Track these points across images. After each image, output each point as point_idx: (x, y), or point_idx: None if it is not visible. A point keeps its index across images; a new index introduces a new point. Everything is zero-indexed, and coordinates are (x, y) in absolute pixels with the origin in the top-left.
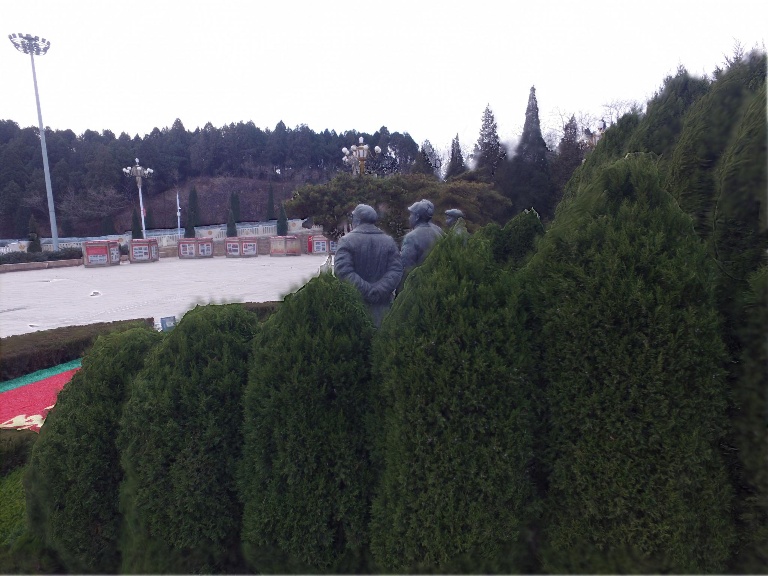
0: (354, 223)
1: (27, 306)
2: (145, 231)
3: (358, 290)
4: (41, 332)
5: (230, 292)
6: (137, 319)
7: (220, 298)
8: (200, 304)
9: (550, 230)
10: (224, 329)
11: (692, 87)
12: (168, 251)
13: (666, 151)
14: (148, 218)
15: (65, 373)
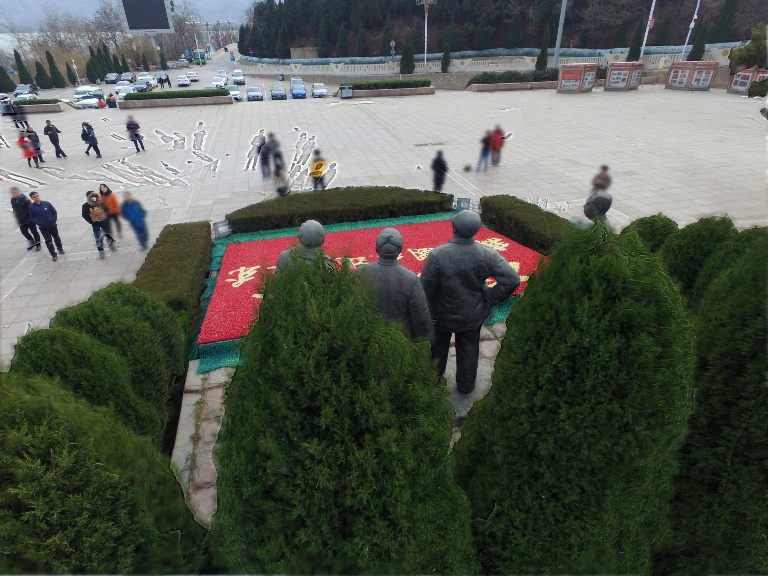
0: None
1: (448, 142)
2: (644, 48)
3: (53, 351)
4: (375, 188)
5: (616, 164)
6: (441, 193)
7: (589, 172)
8: (556, 177)
9: None
10: (64, 325)
11: None
12: (660, 75)
13: None
14: (653, 31)
15: (347, 232)
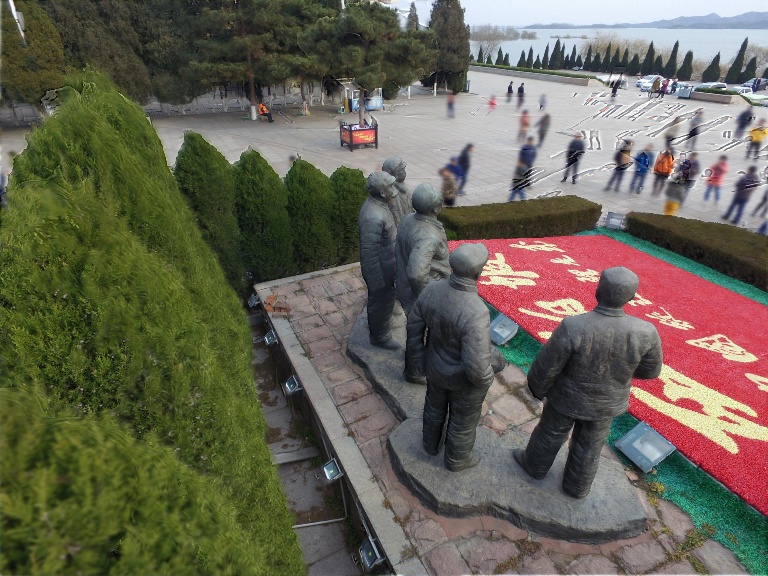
0: None
1: None
2: None
3: (295, 170)
4: None
5: None
6: None
7: None
8: None
9: None
10: None
11: None
12: None
13: None
14: None
15: None
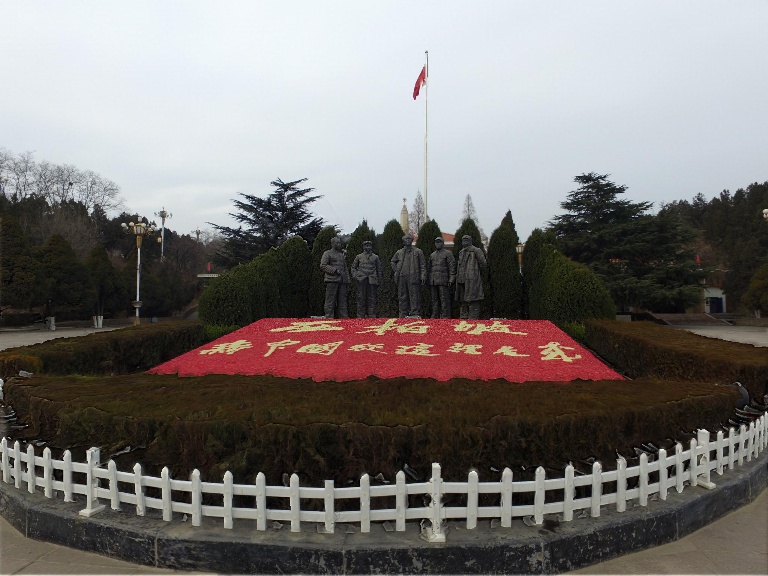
0: None
1: None
2: None
3: None
4: None
5: None
6: None
7: None
8: None
9: None
10: None
11: None
12: None
13: None
14: None
15: None
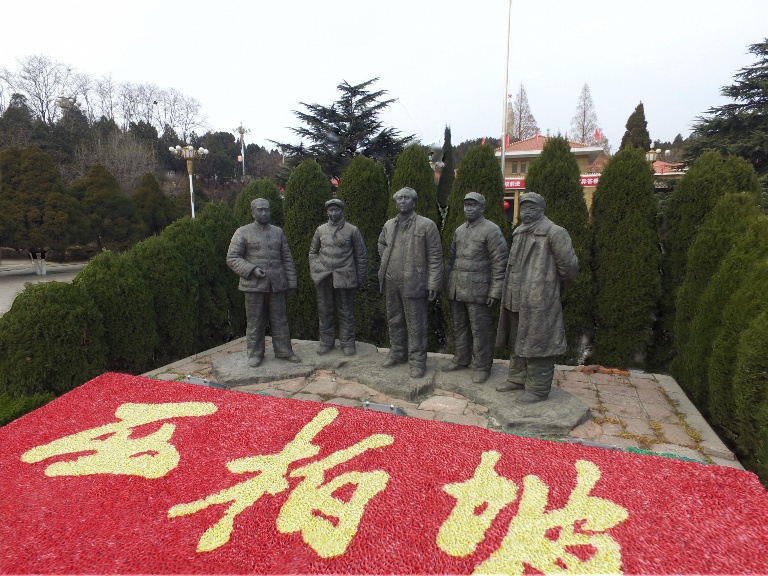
0: (539, 213)
1: None
2: None
3: None
4: None
5: None
6: None
7: None
8: None
9: (753, 220)
10: None
11: (569, 147)
12: None
13: (577, 180)
14: None
15: None
